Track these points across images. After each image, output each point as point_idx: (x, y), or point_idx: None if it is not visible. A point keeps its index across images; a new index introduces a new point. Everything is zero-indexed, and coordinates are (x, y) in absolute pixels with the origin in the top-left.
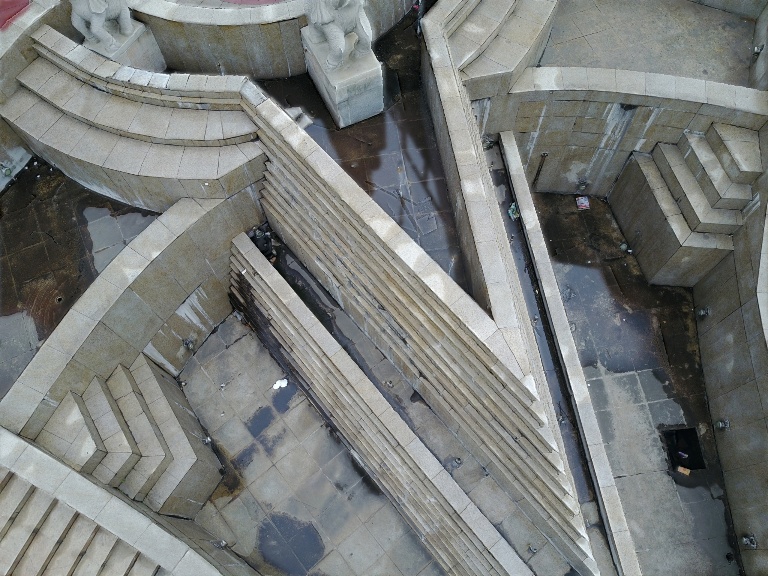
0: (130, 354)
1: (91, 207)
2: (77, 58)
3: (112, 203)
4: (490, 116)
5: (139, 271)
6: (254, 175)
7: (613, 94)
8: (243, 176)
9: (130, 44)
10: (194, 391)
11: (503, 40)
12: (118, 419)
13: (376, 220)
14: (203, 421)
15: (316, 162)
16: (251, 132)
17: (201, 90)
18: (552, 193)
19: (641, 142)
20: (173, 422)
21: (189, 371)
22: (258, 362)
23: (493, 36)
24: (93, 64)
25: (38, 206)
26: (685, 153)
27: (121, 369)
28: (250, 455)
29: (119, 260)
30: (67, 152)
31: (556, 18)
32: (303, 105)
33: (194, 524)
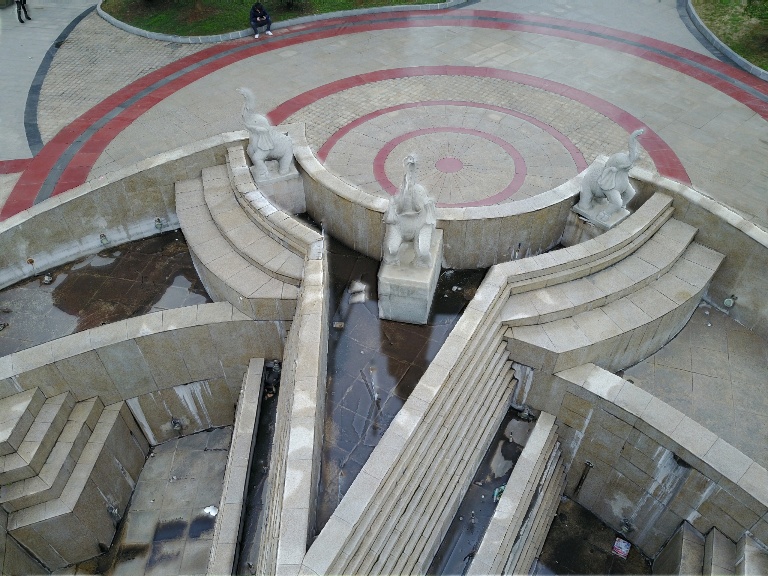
0: (113, 395)
1: (184, 277)
2: (237, 173)
3: (198, 282)
4: (533, 388)
5: (150, 332)
6: (285, 314)
7: (666, 437)
8: (274, 309)
9: (279, 181)
10: (153, 466)
11: (572, 323)
12: (49, 433)
13: (303, 394)
14: (136, 495)
15: (306, 322)
16: (298, 278)
17: (286, 230)
18: (595, 515)
19: (695, 515)
20: (88, 468)
21: (165, 448)
22: (214, 479)
23: (563, 314)
24: (242, 181)
25: (157, 257)
26: (738, 559)
27: (95, 401)
28: (137, 552)
29: (148, 317)
30: (182, 227)
31: (674, 341)
32: (370, 286)
33: (45, 574)
